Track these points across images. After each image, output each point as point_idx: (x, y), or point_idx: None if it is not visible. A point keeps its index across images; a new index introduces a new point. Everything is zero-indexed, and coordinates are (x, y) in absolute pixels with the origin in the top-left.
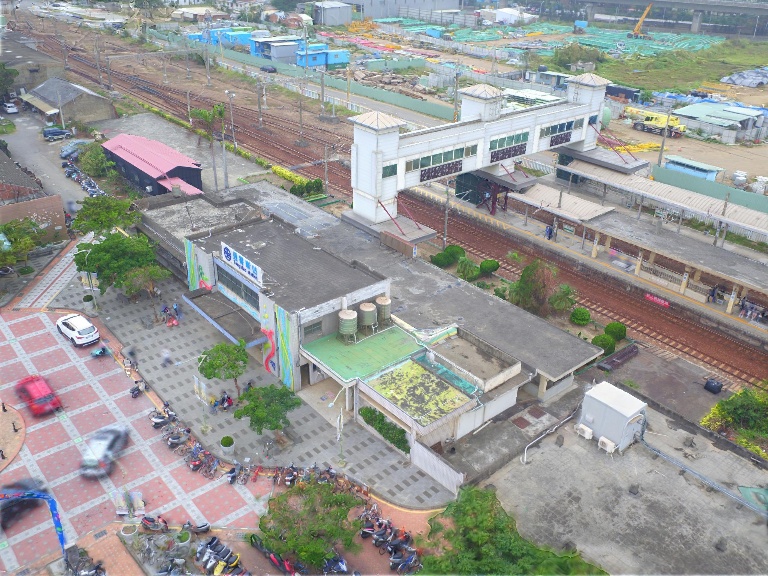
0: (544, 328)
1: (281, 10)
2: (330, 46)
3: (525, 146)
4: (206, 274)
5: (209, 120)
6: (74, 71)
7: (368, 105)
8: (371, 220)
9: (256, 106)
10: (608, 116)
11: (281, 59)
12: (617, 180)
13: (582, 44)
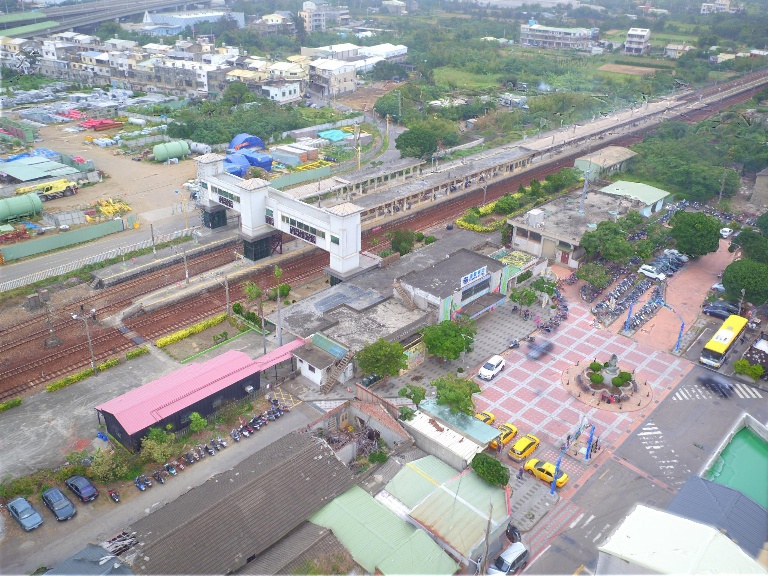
0: None
1: None
2: None
3: None
4: None
5: None
6: None
7: None
8: (356, 268)
9: None
10: None
11: None
12: None
13: None
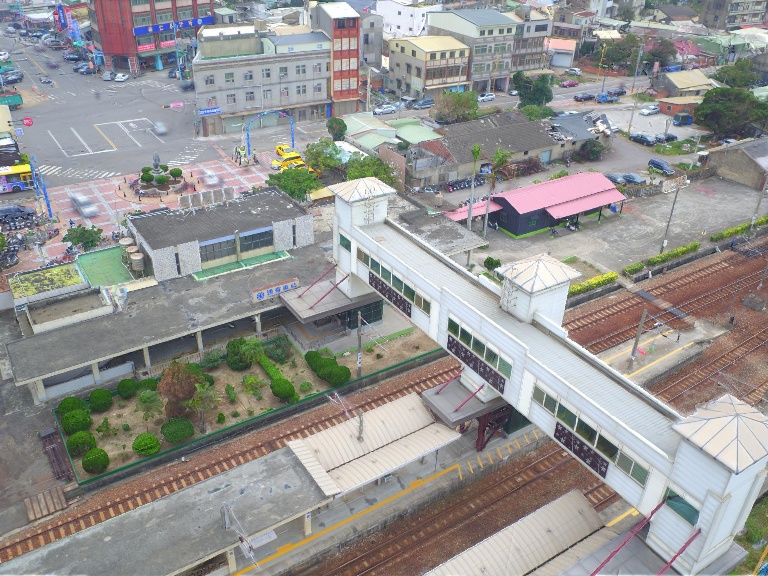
0: (81, 358)
1: None
2: None
3: (503, 382)
4: None
5: (495, 162)
6: None
7: None
8: None
9: None
10: None
11: None
12: None
13: None
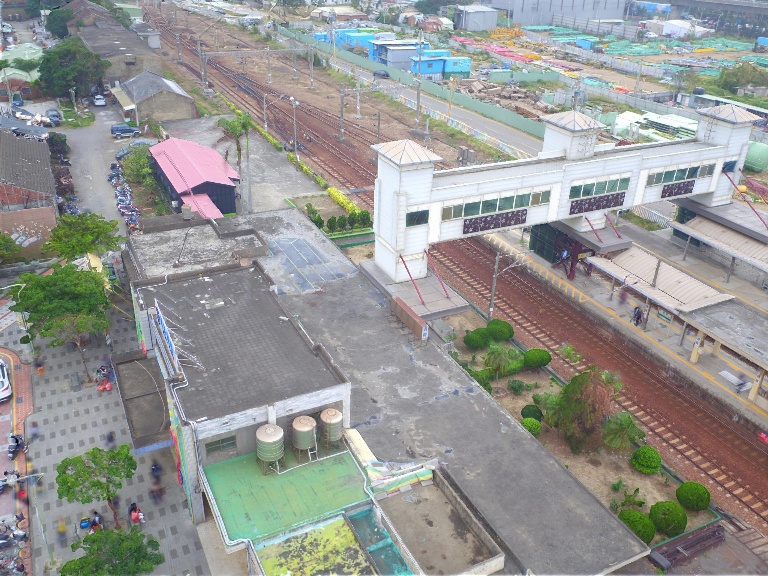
0: (568, 489)
1: (421, 12)
2: (459, 53)
3: (623, 196)
4: (142, 334)
5: (237, 132)
6: (186, 66)
7: (473, 121)
8: (391, 277)
9: (350, 114)
10: (767, 156)
11: (397, 64)
12: (751, 251)
13: (760, 64)
